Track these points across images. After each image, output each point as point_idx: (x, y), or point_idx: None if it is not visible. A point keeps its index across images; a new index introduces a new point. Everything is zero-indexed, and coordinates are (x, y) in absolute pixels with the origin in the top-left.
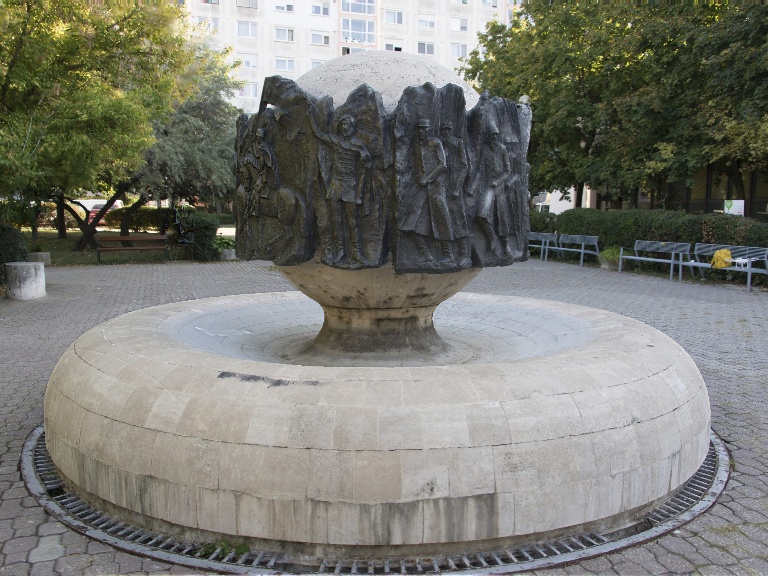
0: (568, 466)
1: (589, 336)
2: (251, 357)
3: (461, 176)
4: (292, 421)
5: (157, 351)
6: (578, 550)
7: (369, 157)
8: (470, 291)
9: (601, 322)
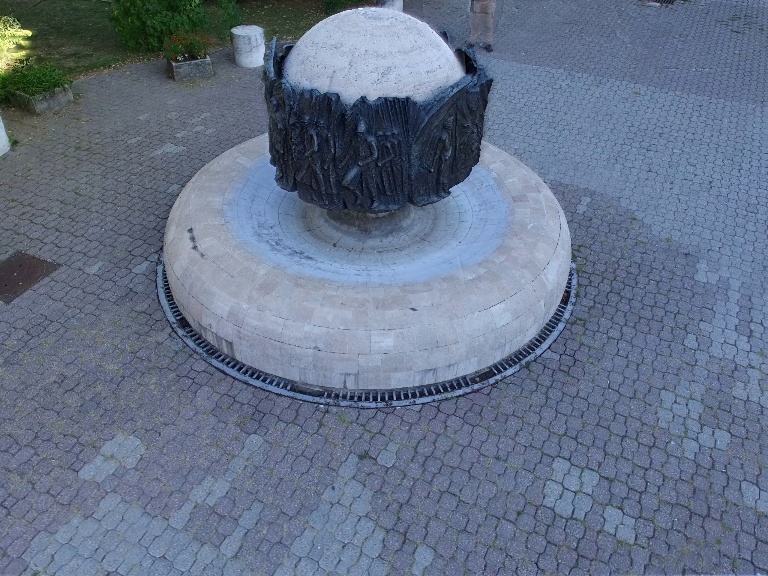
0: (265, 350)
1: (433, 277)
2: (286, 196)
3: (328, 157)
4: (184, 270)
5: (202, 195)
6: (268, 384)
7: (282, 129)
8: (767, 106)
9: (479, 266)
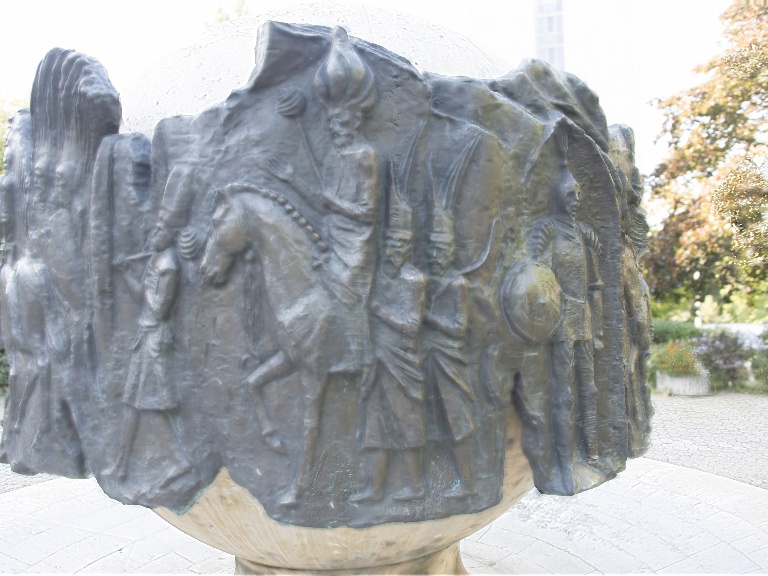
0: None
1: None
2: None
3: None
4: None
5: None
6: None
7: None
8: None
9: None
